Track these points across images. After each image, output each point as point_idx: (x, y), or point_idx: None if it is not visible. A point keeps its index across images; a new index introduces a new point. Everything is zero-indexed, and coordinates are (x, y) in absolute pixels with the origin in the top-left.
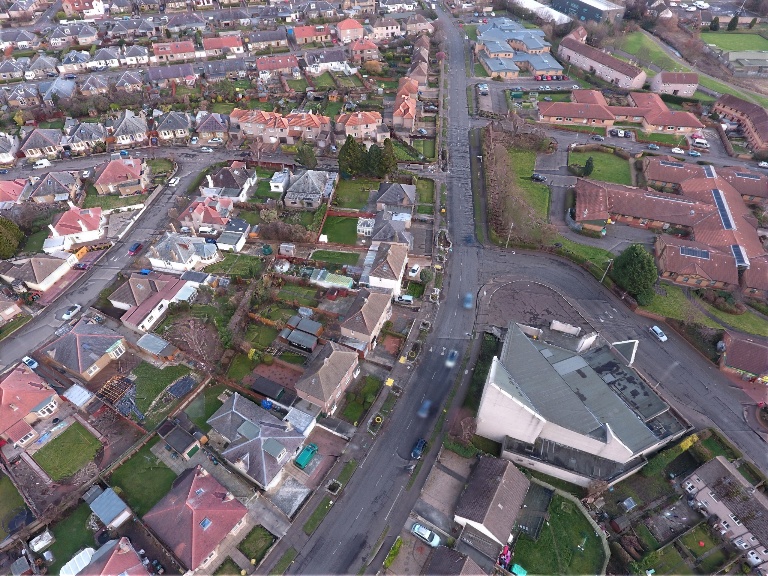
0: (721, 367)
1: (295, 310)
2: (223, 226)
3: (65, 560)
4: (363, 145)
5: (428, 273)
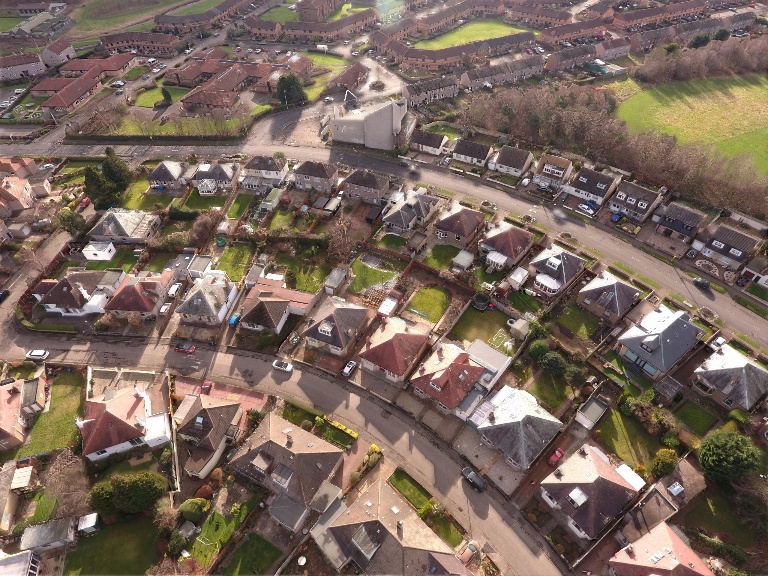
0: (350, 89)
1: (299, 218)
2: (174, 275)
3: (493, 276)
4: (51, 201)
5: (279, 152)
